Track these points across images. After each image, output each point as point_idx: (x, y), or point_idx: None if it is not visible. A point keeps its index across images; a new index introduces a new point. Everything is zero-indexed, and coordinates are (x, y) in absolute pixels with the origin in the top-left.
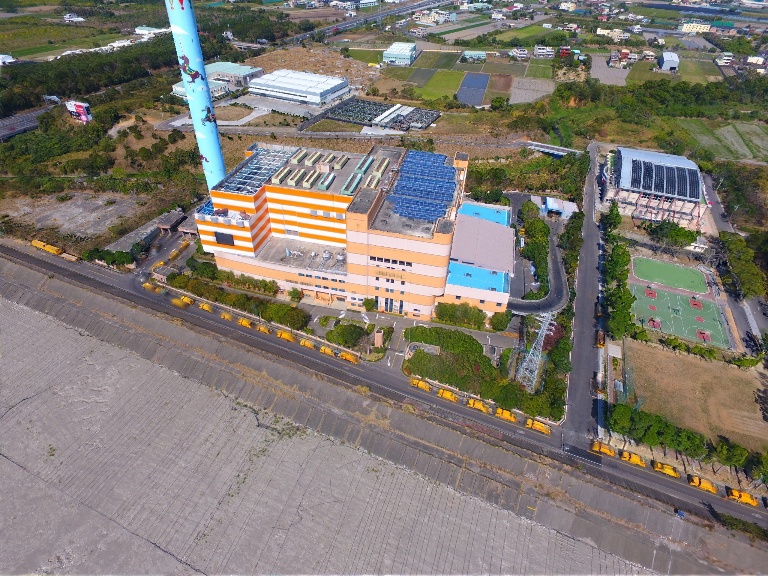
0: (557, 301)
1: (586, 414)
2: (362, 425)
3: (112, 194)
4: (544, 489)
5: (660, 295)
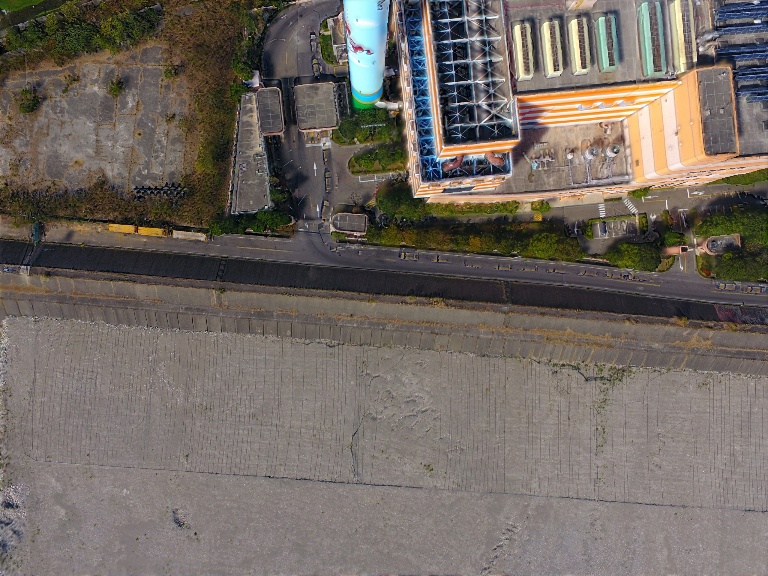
0: None
1: None
2: (686, 352)
3: (91, 58)
4: None
5: None
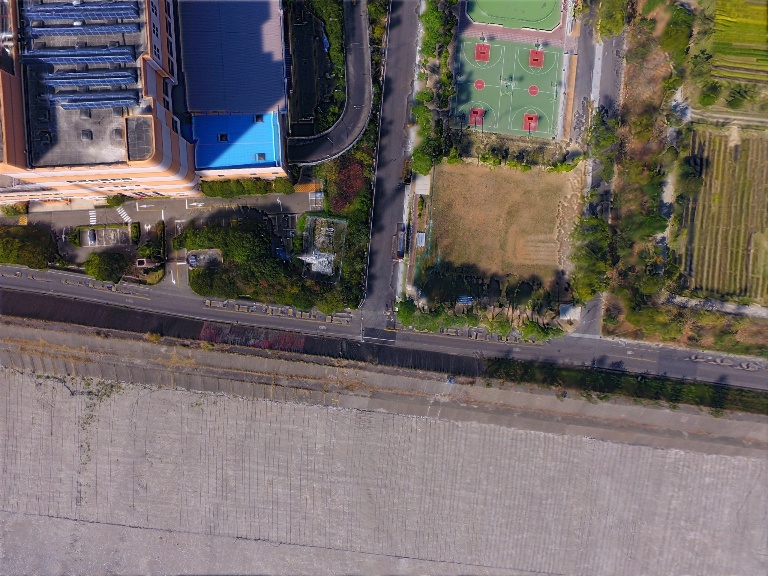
0: (356, 119)
1: (385, 286)
2: (169, 370)
3: None
4: (344, 384)
5: (494, 53)
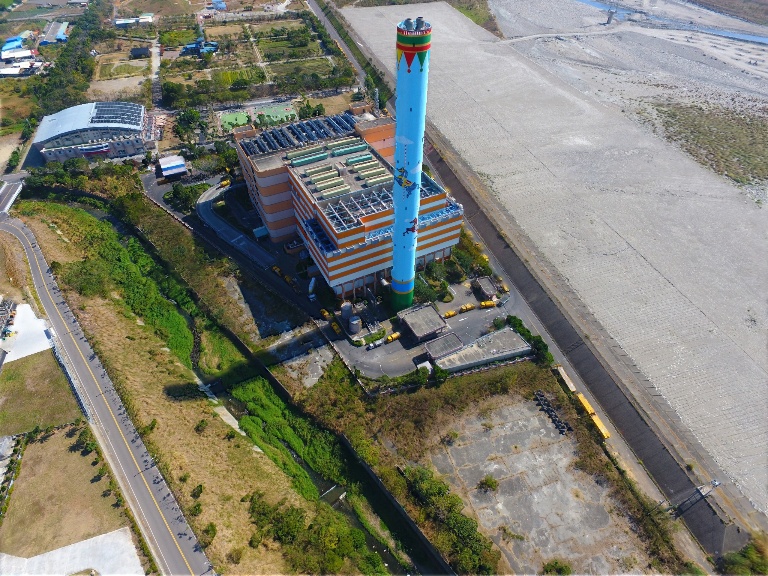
0: None
1: None
2: (455, 157)
3: None
4: None
5: None
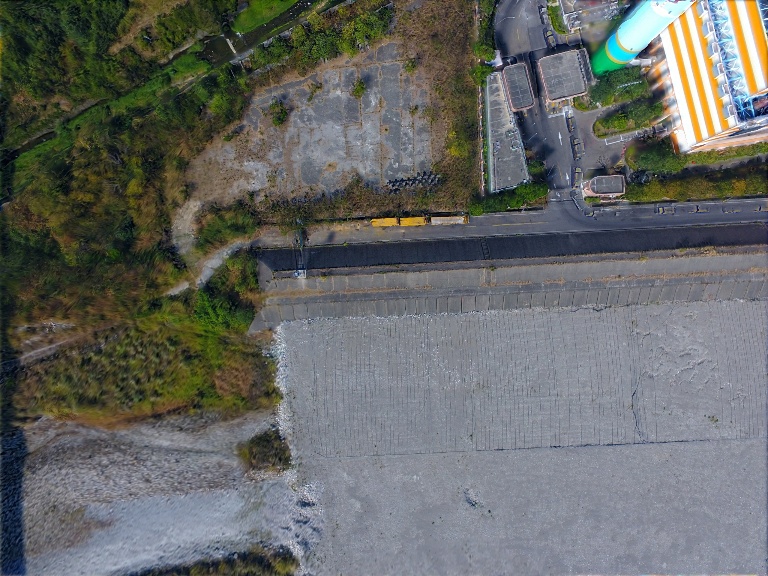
0: None
1: None
2: None
3: (331, 64)
4: None
5: None
